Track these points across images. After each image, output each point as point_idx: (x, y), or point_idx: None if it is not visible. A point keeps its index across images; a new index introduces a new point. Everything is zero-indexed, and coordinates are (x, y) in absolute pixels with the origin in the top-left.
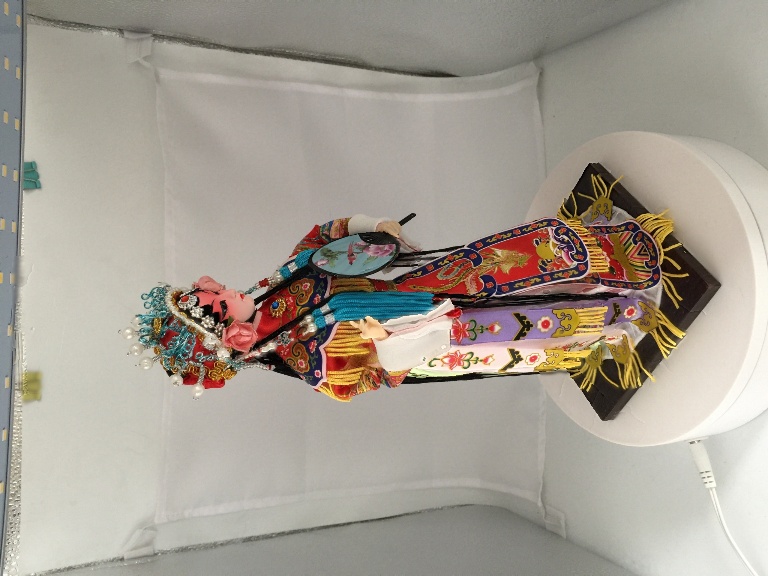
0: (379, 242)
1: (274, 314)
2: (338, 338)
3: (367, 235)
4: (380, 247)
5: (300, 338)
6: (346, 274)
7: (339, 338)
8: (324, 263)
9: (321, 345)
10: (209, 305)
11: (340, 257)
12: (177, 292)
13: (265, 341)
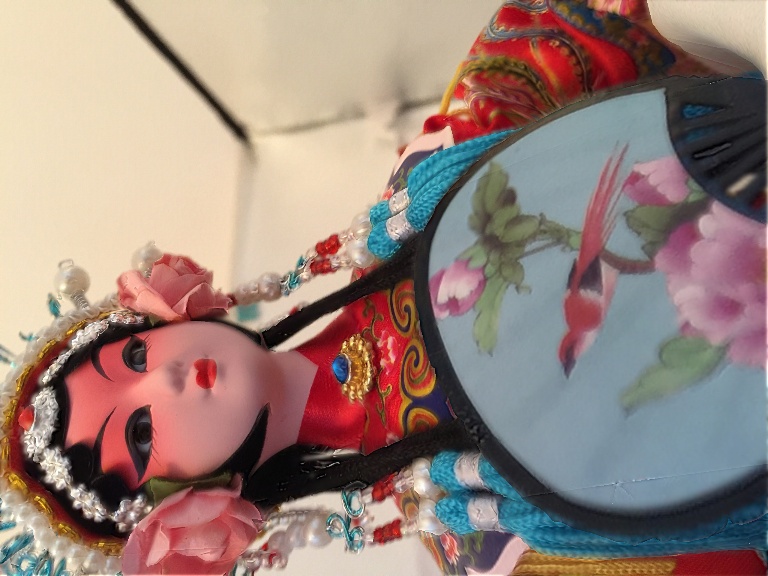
0: (767, 189)
1: (345, 386)
2: (528, 573)
3: (710, 102)
4: (763, 252)
5: (416, 495)
6: (519, 460)
7: (532, 574)
8: (460, 298)
9: (470, 569)
10: (84, 448)
11: (533, 276)
12: (55, 343)
13: (313, 487)
